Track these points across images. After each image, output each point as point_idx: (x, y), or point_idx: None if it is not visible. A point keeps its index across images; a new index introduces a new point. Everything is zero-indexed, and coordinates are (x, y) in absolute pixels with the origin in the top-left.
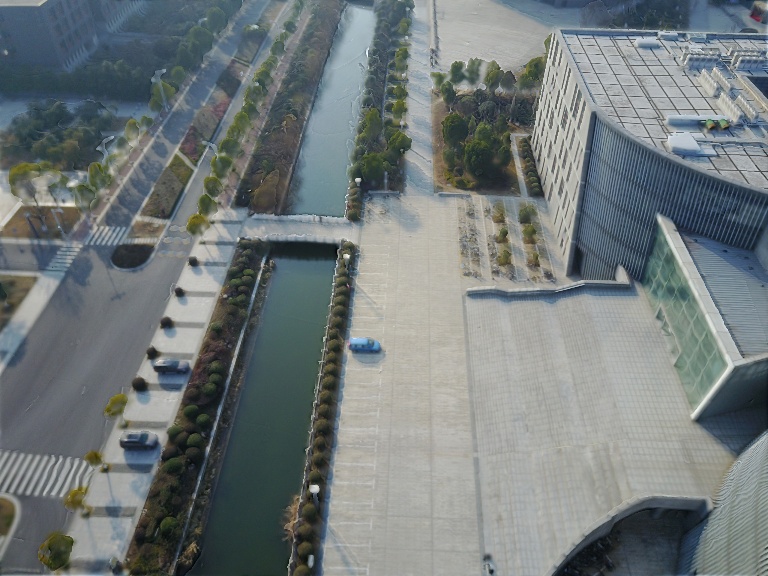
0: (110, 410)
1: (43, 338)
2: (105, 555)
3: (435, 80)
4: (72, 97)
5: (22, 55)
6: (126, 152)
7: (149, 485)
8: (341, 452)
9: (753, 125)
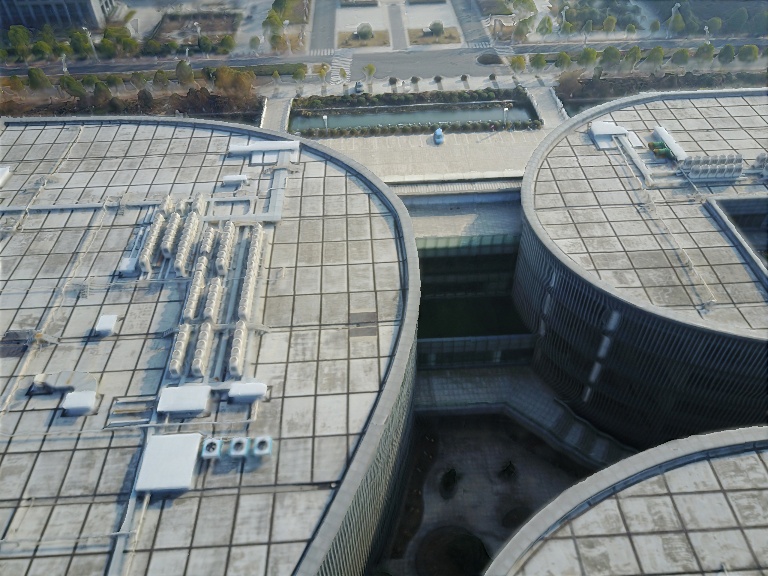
0: (366, 68)
1: None
2: None
3: None
4: (652, 7)
5: None
6: (585, 30)
7: (337, 95)
8: (360, 139)
9: (686, 176)
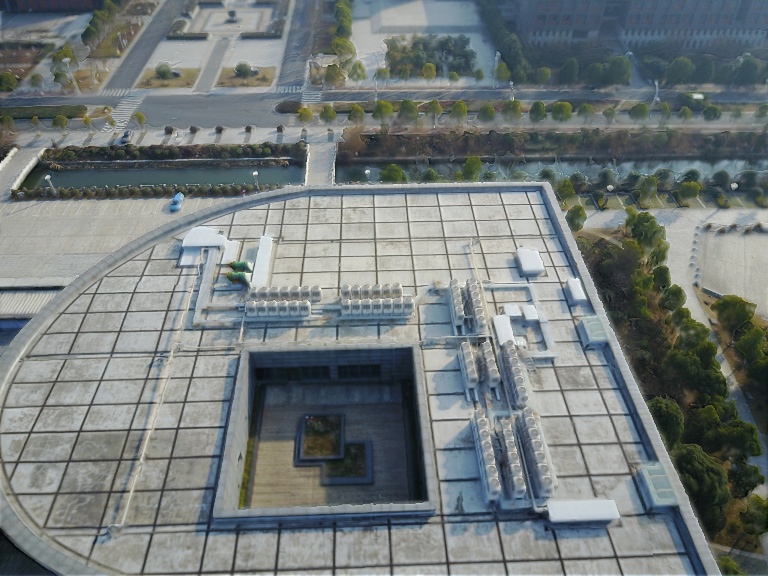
0: (135, 115)
1: (219, 100)
2: (64, 142)
3: (627, 217)
4: None
5: (522, 13)
6: (402, 77)
7: None
8: (91, 202)
9: None
